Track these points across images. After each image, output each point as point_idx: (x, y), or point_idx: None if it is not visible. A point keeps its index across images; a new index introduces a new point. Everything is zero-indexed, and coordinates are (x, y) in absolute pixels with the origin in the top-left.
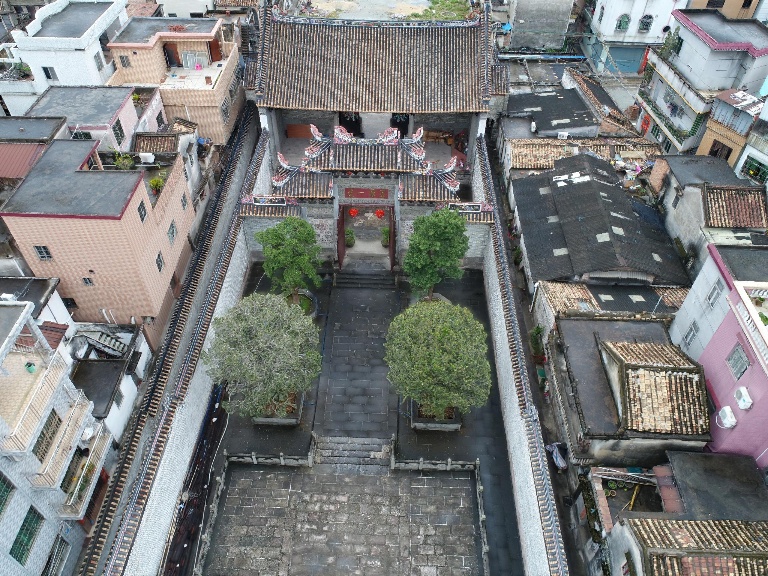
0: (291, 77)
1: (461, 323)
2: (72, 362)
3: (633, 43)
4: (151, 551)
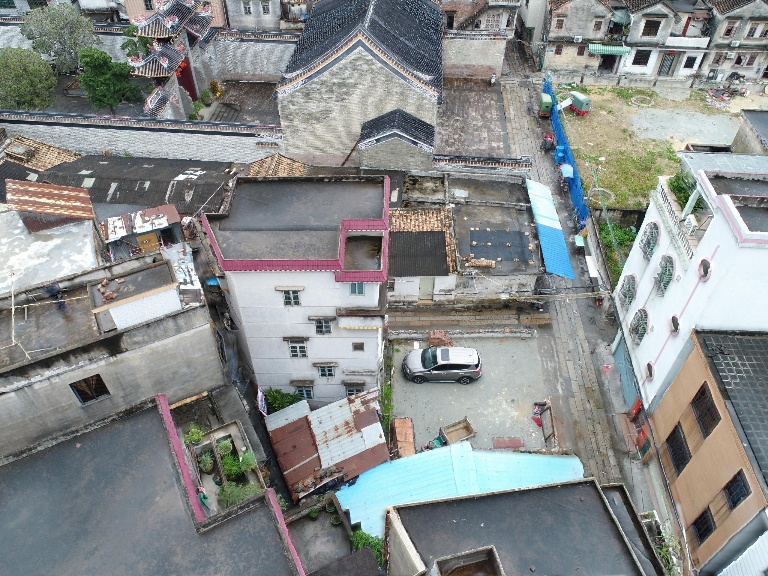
0: (333, 6)
1: (1, 61)
2: (107, 7)
3: (625, 341)
4: (5, 46)
